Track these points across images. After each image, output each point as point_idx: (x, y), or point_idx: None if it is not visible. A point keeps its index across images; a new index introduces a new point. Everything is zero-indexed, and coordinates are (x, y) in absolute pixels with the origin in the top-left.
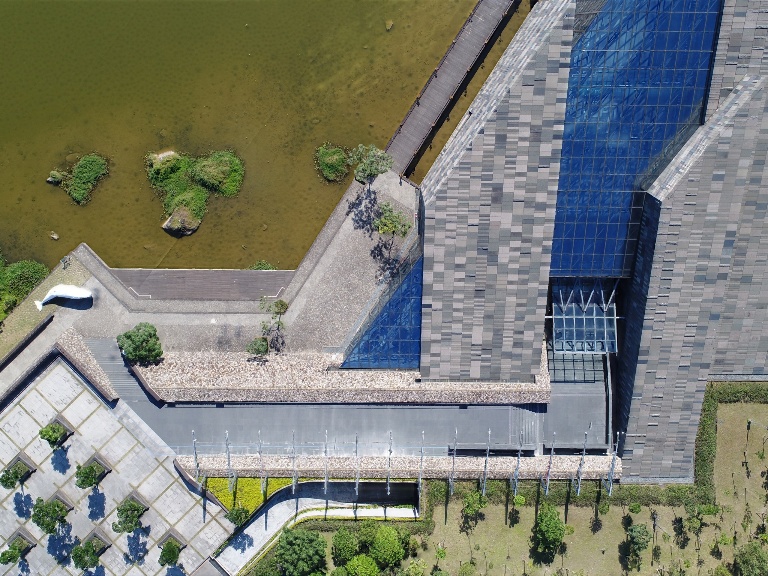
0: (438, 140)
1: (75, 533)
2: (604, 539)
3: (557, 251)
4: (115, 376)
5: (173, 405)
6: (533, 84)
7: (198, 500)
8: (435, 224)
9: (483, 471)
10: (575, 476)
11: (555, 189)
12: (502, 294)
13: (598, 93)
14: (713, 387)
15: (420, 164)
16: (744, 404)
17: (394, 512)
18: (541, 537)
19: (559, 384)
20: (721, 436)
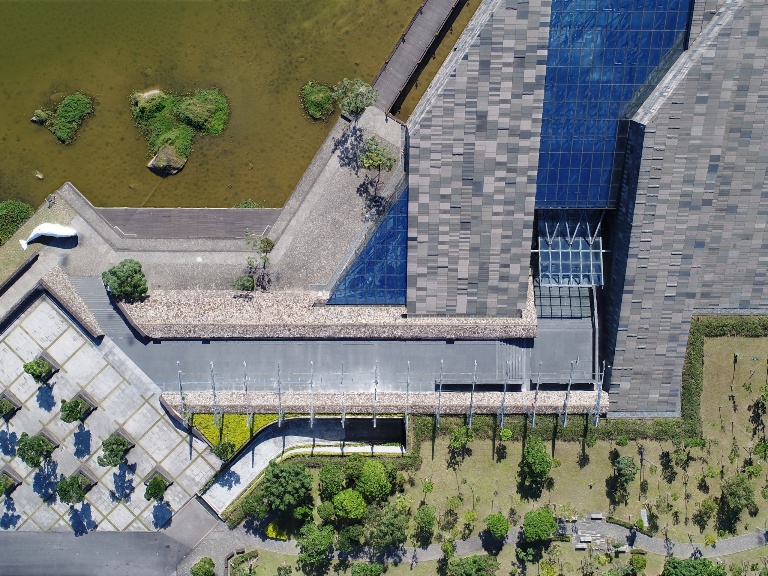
0: (424, 78)
1: (61, 471)
2: (591, 474)
3: (542, 182)
4: (100, 314)
5: (159, 342)
6: (516, 8)
7: (184, 437)
8: (420, 153)
9: (470, 404)
10: (562, 410)
11: (539, 117)
12: (488, 226)
13: (581, 17)
14: (699, 321)
15: (406, 102)
16: (730, 338)
17: (381, 449)
18: (528, 470)
19: (546, 320)
20: (708, 370)
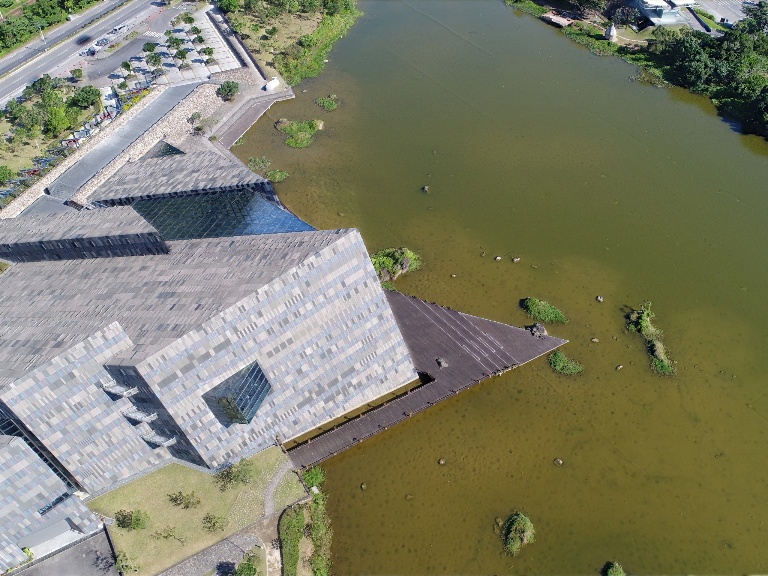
0: None
1: None
2: None
3: None
4: None
5: None
6: None
7: None
8: None
9: None
10: None
11: None
12: None
13: None
14: None
15: None
16: None
17: None
18: None
19: None
20: None
